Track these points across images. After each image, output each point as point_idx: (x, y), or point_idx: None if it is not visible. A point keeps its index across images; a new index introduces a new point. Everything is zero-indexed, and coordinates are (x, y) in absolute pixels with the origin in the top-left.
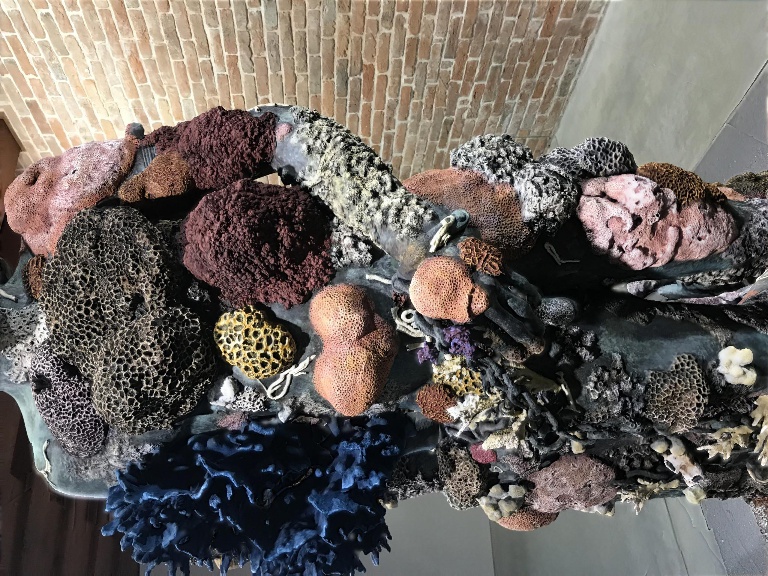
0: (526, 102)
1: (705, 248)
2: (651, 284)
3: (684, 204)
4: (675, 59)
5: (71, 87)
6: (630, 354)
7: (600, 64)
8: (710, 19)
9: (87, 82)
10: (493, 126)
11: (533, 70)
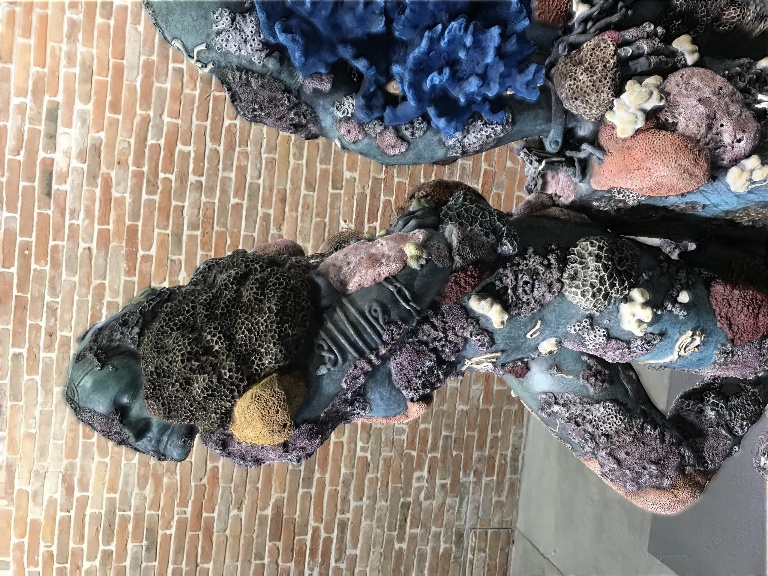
0: (480, 482)
1: None
2: None
3: None
4: None
5: (7, 437)
6: None
7: None
8: None
9: (27, 434)
10: (451, 512)
11: (481, 442)
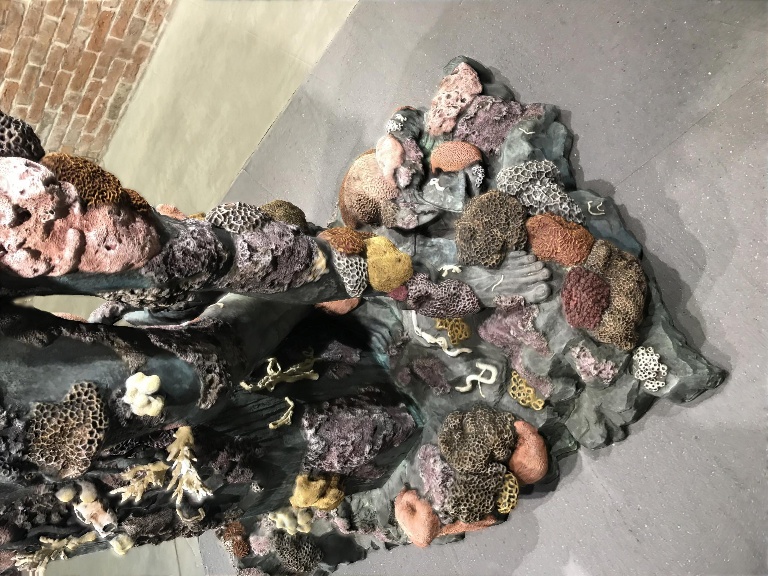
0: (70, 116)
1: (116, 260)
2: (118, 309)
3: (90, 205)
4: (213, 104)
5: None
6: (13, 382)
7: (150, 94)
8: (242, 73)
9: None
10: None
11: (78, 83)
